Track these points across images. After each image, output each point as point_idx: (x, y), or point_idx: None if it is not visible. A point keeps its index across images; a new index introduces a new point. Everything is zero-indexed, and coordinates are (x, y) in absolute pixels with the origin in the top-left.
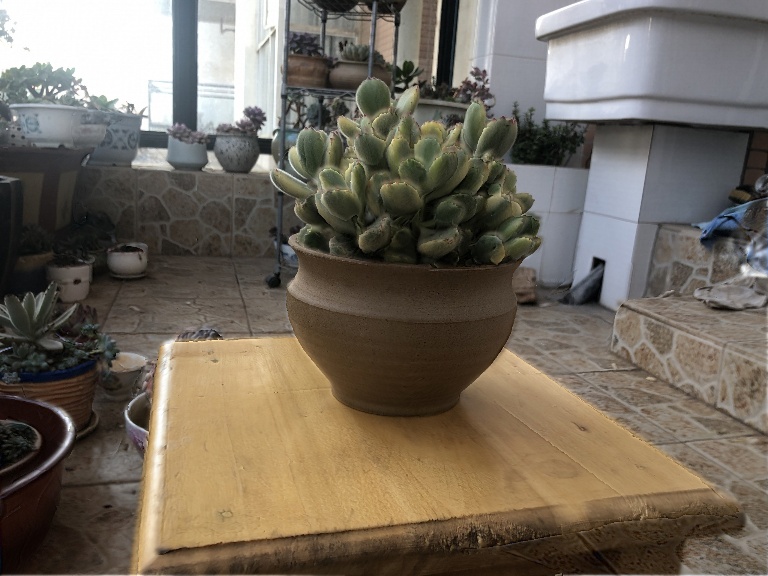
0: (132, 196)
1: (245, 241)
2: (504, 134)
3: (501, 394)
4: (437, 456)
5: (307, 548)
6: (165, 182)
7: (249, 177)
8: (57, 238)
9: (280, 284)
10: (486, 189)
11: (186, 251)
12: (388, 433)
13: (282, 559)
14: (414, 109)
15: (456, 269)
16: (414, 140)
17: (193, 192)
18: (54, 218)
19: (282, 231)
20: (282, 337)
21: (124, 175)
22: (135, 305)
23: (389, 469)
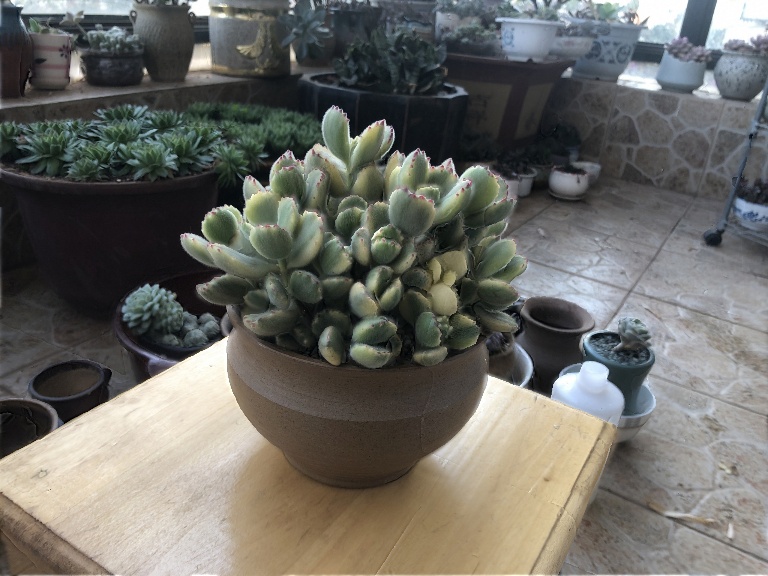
0: (607, 113)
1: (718, 182)
2: (404, 206)
3: (445, 504)
4: (242, 527)
5: (34, 534)
6: (644, 102)
7: (747, 107)
8: (507, 148)
9: (720, 243)
10: (368, 270)
11: (648, 180)
12: (256, 478)
13: (17, 530)
14: (370, 146)
15: (282, 353)
16: (311, 192)
17: (672, 117)
18: (515, 128)
19: (748, 181)
20: (661, 307)
21: (604, 90)
22: (543, 228)
23: (186, 512)
